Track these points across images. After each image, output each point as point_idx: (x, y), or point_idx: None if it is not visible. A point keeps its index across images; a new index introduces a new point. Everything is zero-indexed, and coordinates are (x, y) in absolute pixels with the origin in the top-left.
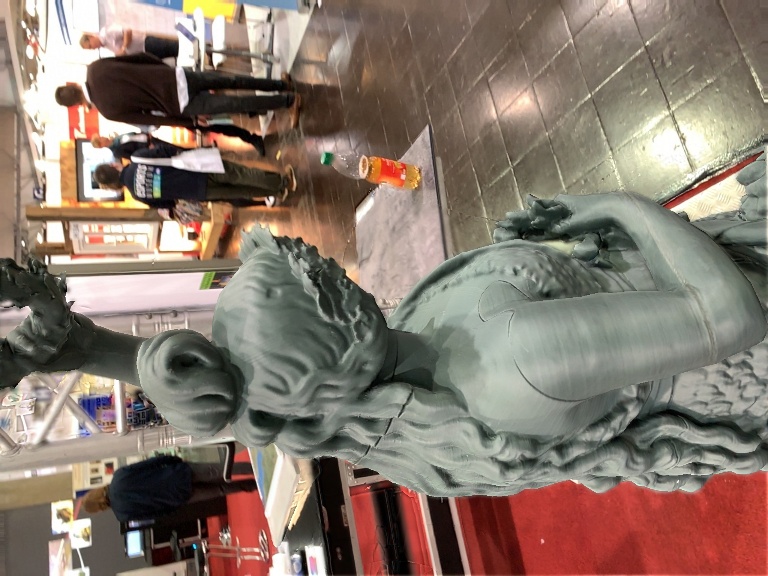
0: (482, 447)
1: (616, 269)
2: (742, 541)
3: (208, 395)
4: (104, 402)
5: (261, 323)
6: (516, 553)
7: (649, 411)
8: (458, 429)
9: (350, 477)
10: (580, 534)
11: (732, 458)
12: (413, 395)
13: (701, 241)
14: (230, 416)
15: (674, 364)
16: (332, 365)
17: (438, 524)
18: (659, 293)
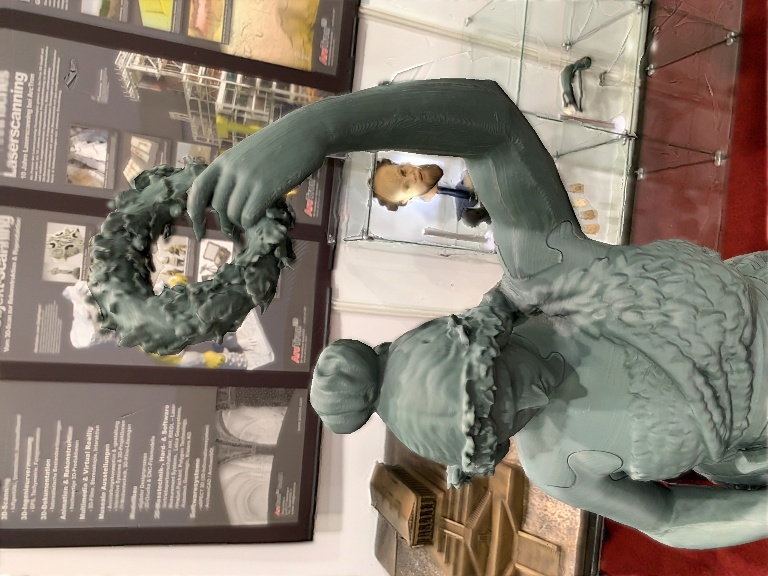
0: None
1: None
2: None
3: None
4: None
5: None
6: None
7: None
8: None
9: None
10: None
11: None
12: None
13: None
14: None
15: None
16: None
17: None
18: (649, 523)
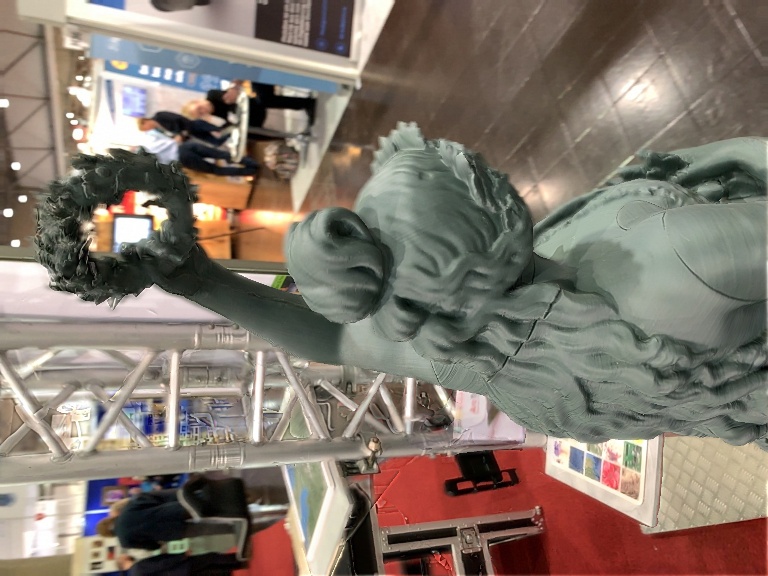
0: (636, 349)
1: None
2: None
3: (361, 267)
4: (156, 418)
5: (414, 201)
6: None
7: None
8: (608, 332)
9: (384, 542)
10: None
11: None
12: (562, 292)
13: None
14: (374, 302)
15: None
16: (482, 251)
17: None
18: None
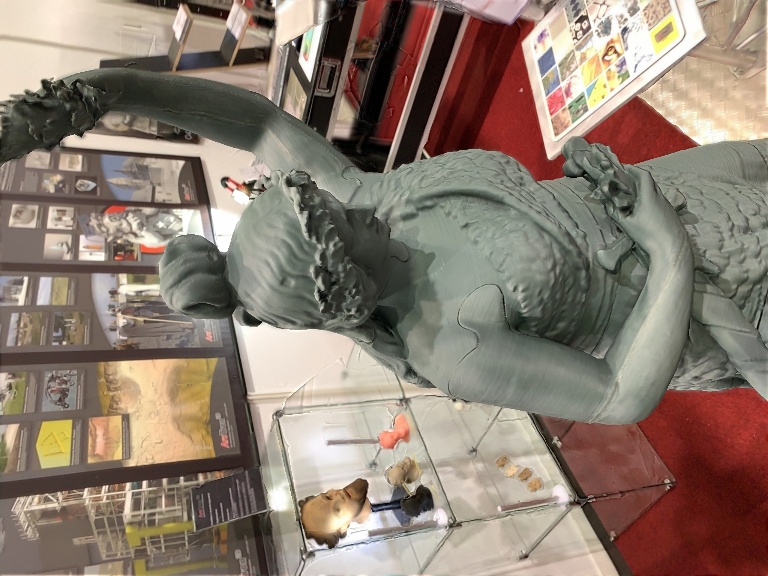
0: (403, 377)
1: (618, 277)
2: None
3: None
4: None
5: (269, 298)
6: (496, 81)
7: None
8: (394, 362)
9: None
10: None
11: None
12: (372, 344)
13: (667, 356)
14: None
15: None
16: (317, 324)
17: (443, 30)
18: (592, 379)
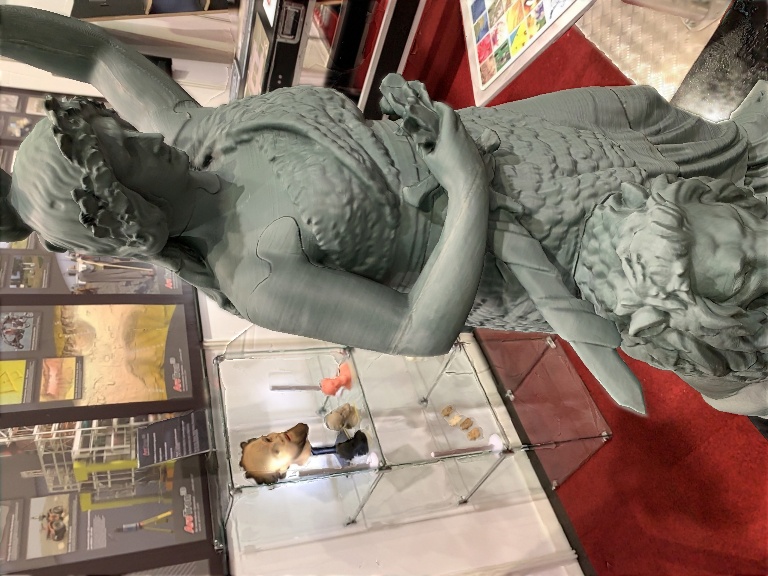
0: None
1: (431, 215)
2: None
3: None
4: None
5: (45, 221)
6: None
7: None
8: (210, 292)
9: None
10: None
11: None
12: (178, 273)
13: (456, 290)
14: None
15: None
16: (110, 250)
17: None
18: (387, 311)
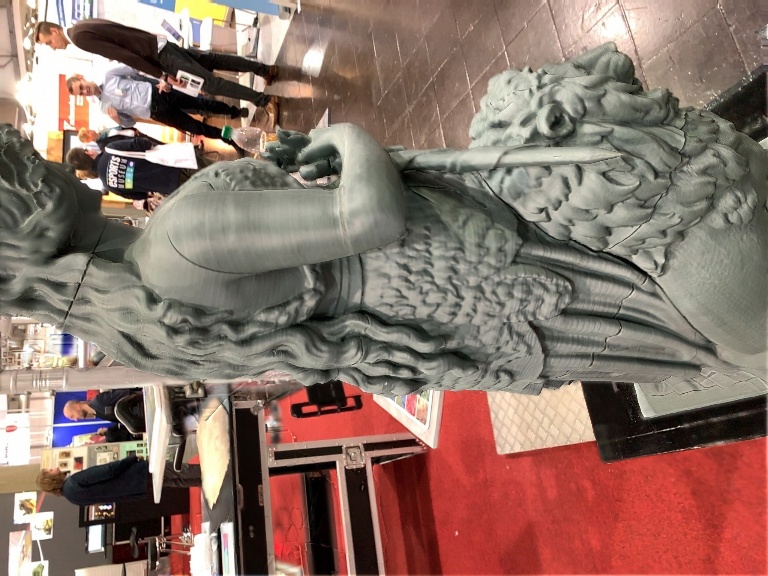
0: (148, 310)
1: None
2: (620, 529)
3: None
4: None
5: None
6: (434, 545)
7: (344, 311)
8: (132, 295)
9: (270, 458)
10: (488, 525)
11: (419, 358)
12: (91, 261)
13: (369, 154)
14: None
15: (310, 246)
16: (13, 227)
17: (355, 510)
18: (315, 190)
